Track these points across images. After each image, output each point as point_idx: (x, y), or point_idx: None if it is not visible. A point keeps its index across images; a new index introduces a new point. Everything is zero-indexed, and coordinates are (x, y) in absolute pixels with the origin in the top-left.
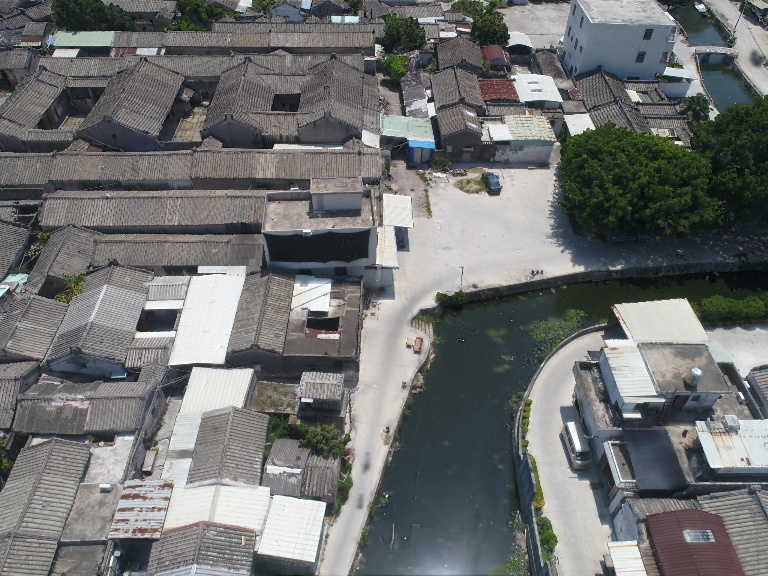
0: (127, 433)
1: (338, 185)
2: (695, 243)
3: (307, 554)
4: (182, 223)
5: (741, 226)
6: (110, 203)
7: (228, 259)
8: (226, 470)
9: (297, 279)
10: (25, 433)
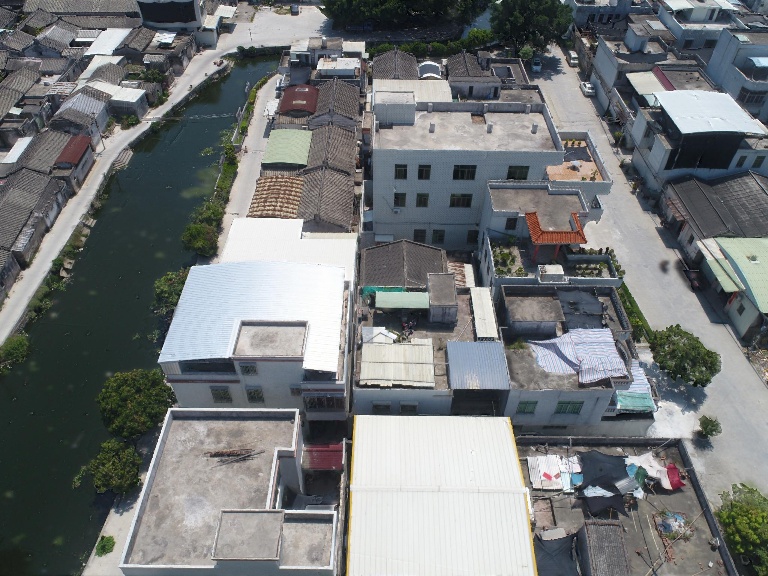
0: (59, 74)
1: None
2: (400, 34)
3: (132, 100)
4: (101, 11)
5: (433, 28)
6: (62, 2)
7: (123, 25)
8: (102, 78)
9: (158, 31)
10: (11, 71)
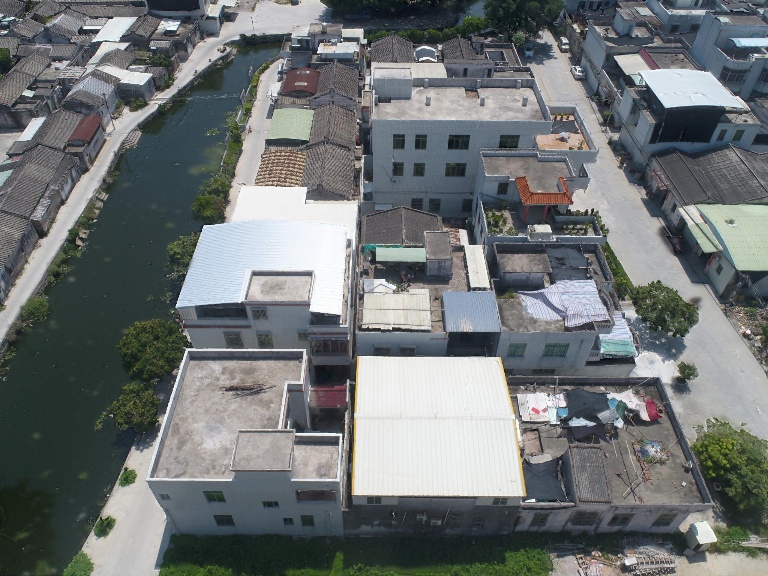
0: (69, 60)
1: None
2: (397, 22)
3: (140, 83)
4: (107, 1)
5: (429, 17)
6: None
7: (129, 13)
8: (110, 62)
9: (163, 19)
10: (22, 57)
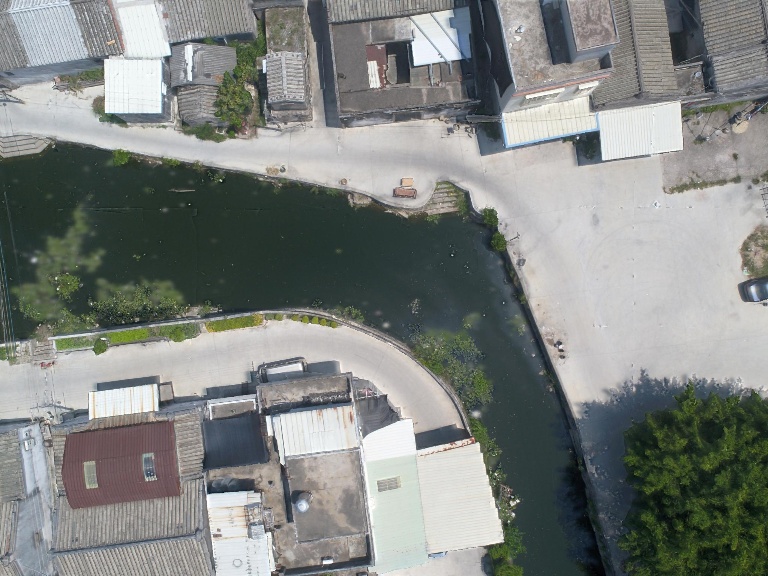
0: None
1: (591, 8)
2: None
3: (110, 105)
4: None
5: None
6: None
7: None
8: (171, 3)
9: (461, 10)
10: None
